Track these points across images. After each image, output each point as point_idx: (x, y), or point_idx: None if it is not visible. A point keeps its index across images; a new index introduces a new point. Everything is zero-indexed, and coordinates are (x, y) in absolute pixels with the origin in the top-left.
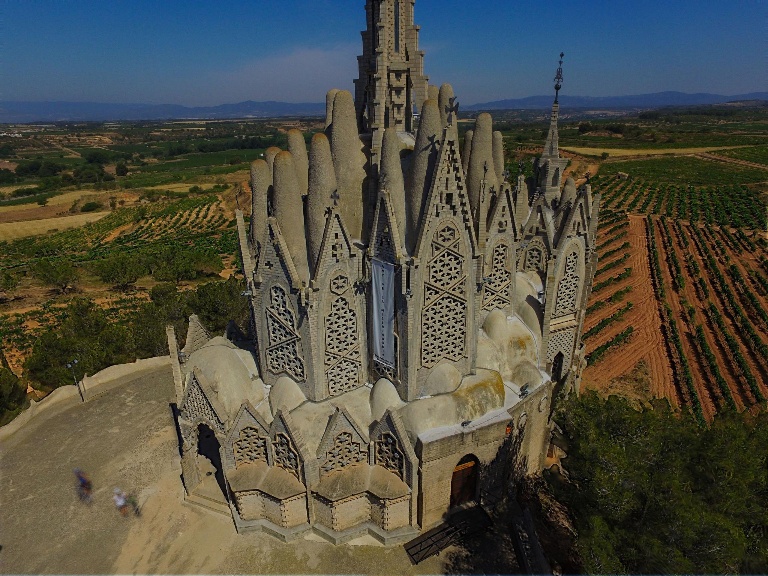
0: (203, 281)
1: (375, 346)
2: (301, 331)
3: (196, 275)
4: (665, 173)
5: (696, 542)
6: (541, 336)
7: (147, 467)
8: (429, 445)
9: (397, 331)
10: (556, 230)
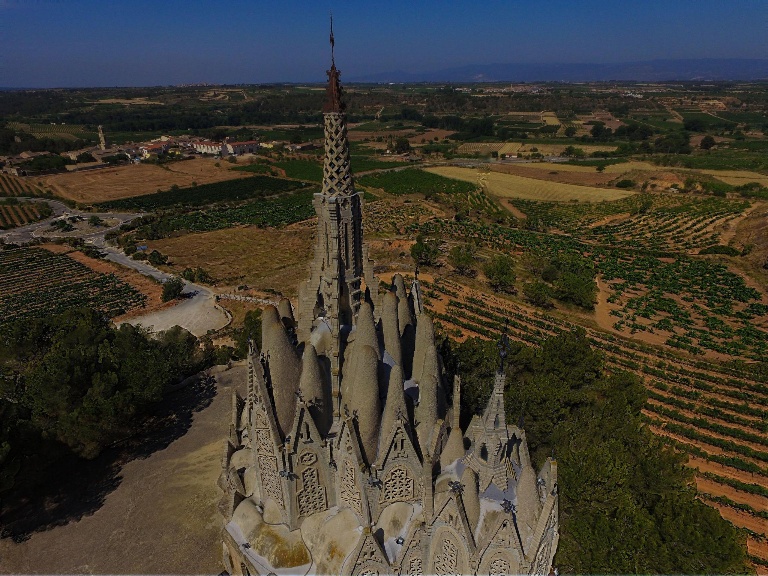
0: (568, 307)
1: None
2: None
3: (569, 299)
4: None
5: None
6: None
7: None
8: (226, 531)
9: None
10: None
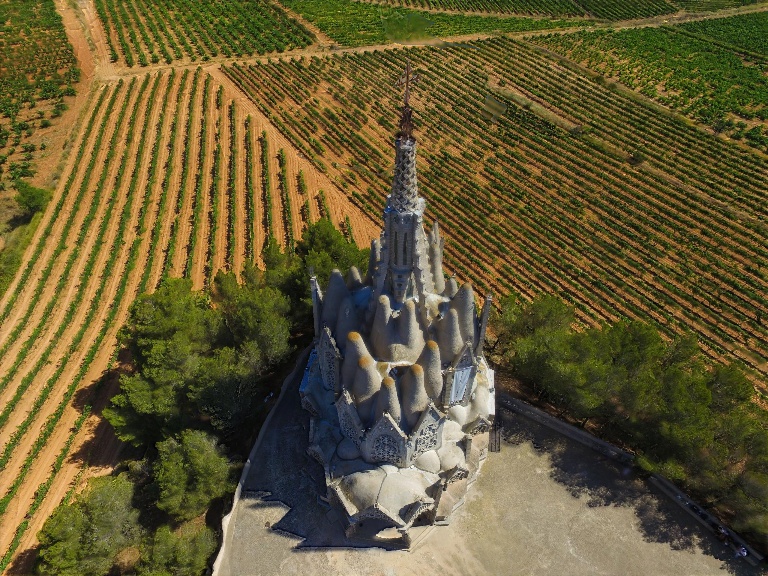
0: None
1: (450, 399)
2: None
3: None
4: None
5: None
6: None
7: (366, 573)
8: None
9: None
10: None
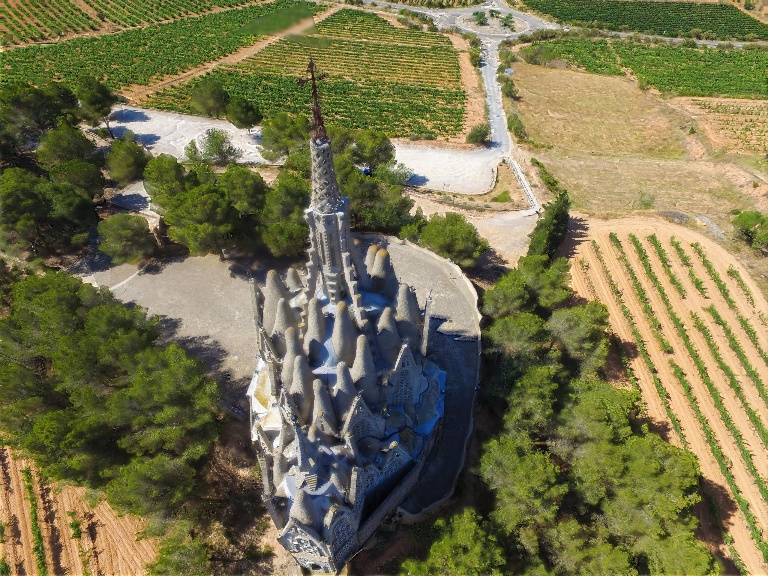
0: None
1: None
2: None
3: None
4: None
5: None
6: None
7: None
8: None
9: None
10: None
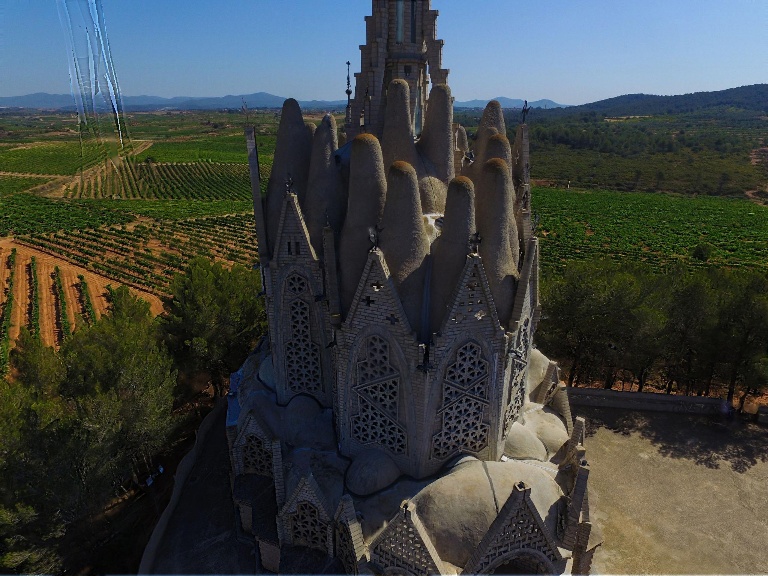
0: None
1: None
2: None
3: None
4: None
5: None
6: None
7: None
8: None
9: None
10: None
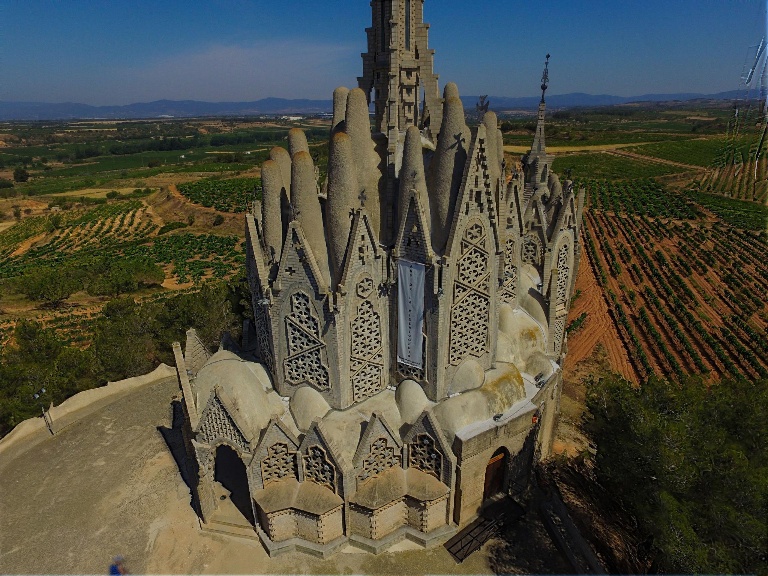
0: (144, 293)
1: (400, 348)
2: (326, 338)
3: None
4: (584, 168)
5: (764, 504)
6: (548, 326)
7: (149, 499)
8: (468, 442)
9: (425, 331)
10: (548, 224)
